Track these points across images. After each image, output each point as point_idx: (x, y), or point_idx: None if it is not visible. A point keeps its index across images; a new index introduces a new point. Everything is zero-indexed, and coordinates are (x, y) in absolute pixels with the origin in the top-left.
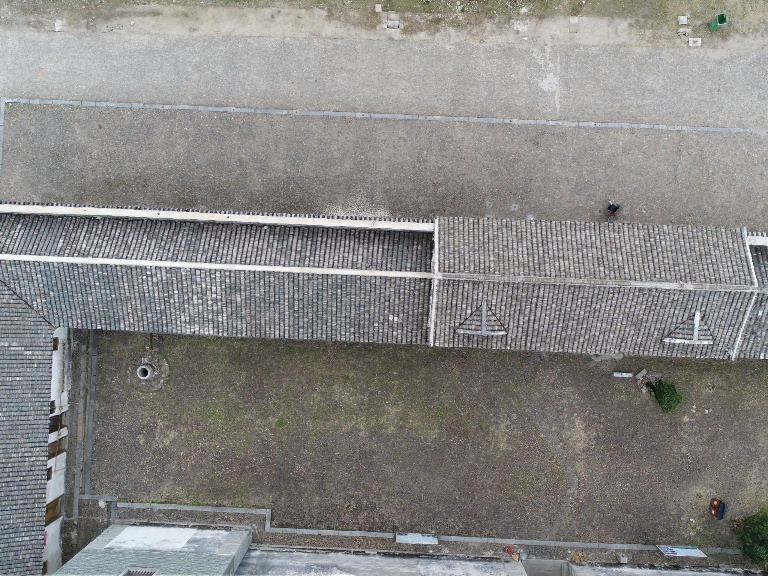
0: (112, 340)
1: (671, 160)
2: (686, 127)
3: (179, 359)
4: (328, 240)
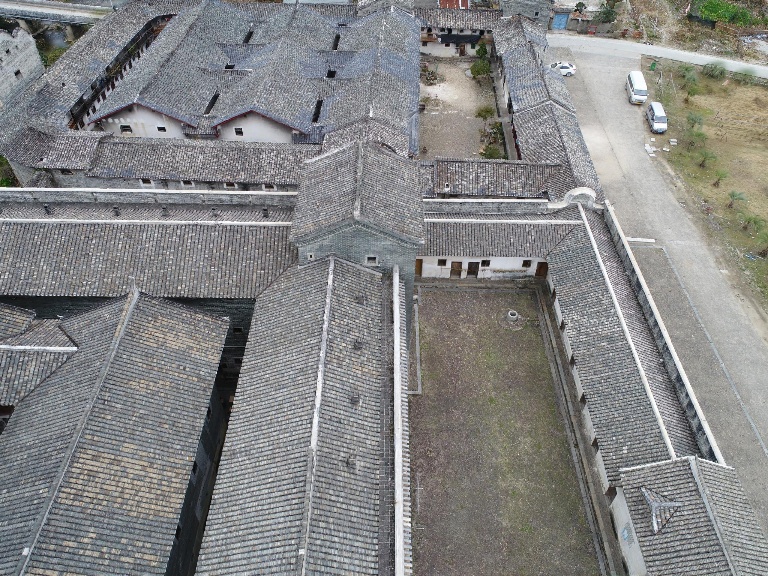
0: (528, 300)
1: None
2: None
3: (525, 336)
4: (670, 399)
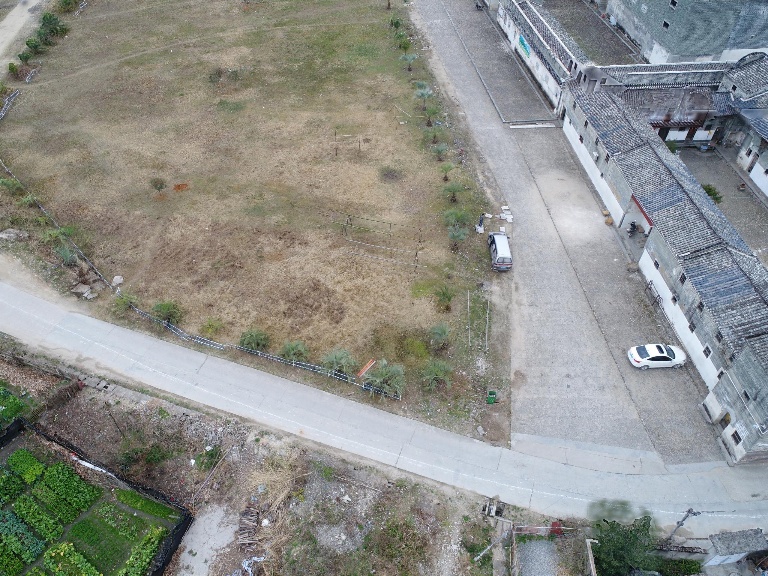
0: None
1: None
2: (442, 2)
3: None
4: None
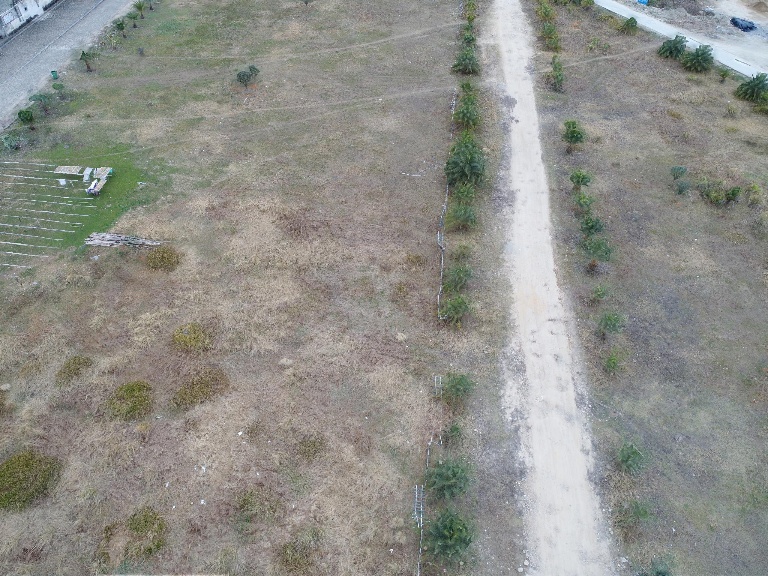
0: None
1: (8, 67)
2: None
3: None
4: None
